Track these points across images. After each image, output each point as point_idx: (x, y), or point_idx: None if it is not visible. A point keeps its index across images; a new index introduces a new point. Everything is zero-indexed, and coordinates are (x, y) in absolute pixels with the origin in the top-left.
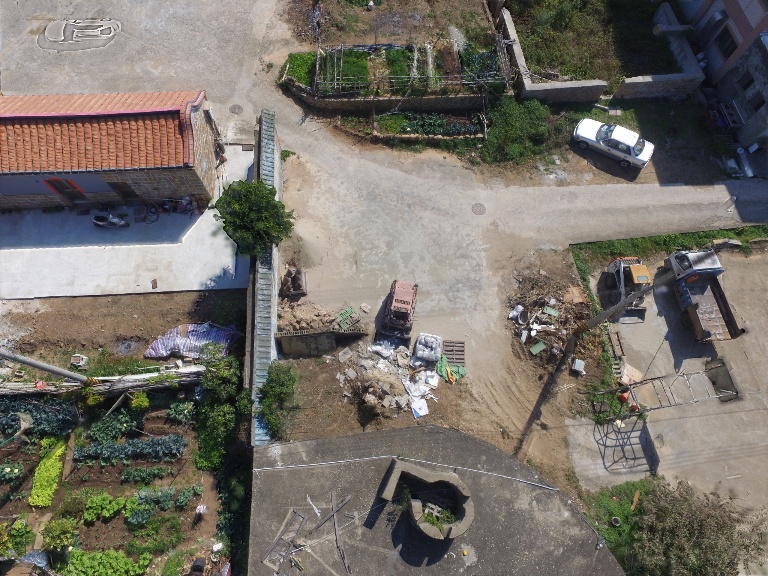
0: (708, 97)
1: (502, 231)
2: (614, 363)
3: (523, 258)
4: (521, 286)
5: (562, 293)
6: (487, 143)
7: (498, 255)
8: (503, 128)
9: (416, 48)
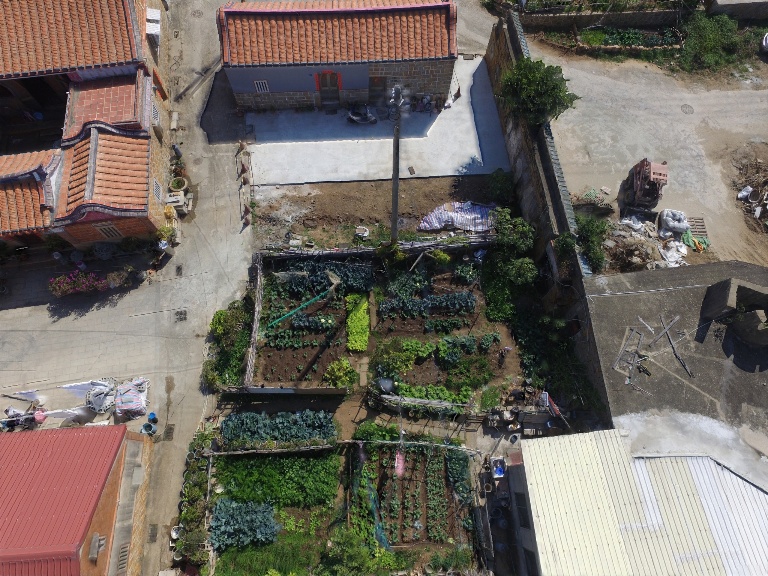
0: None
1: (713, 127)
2: None
3: (738, 149)
4: (743, 172)
5: None
6: (685, 53)
7: (714, 147)
8: (697, 40)
9: None
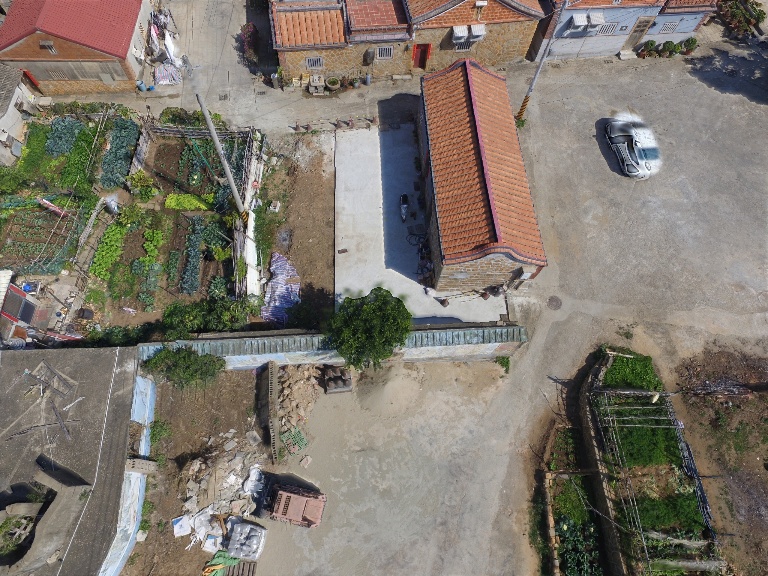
0: None
1: None
2: None
3: None
4: None
5: None
6: None
7: None
8: None
9: None
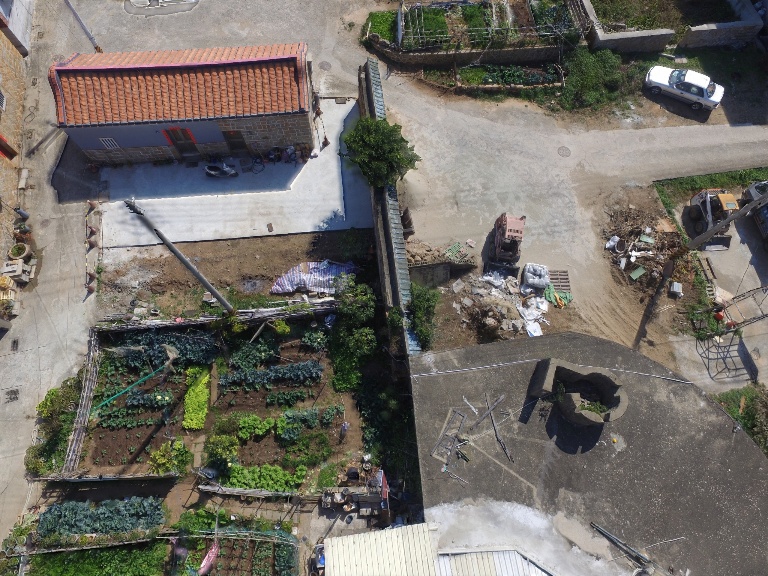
0: (766, 44)
1: (589, 171)
2: (707, 285)
3: (612, 194)
4: (613, 219)
5: (655, 222)
6: (566, 91)
7: (588, 193)
8: (579, 77)
9: (493, 3)
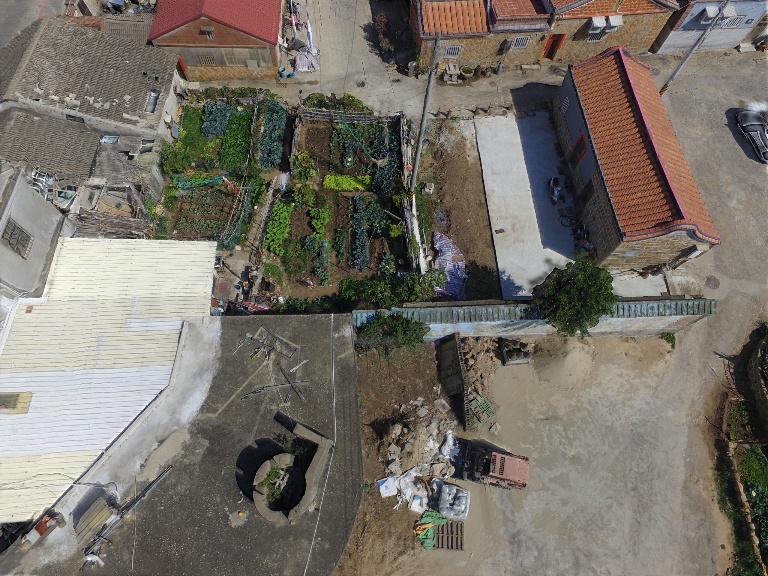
0: None
1: None
2: None
3: None
4: None
5: None
6: None
7: None
8: None
9: None
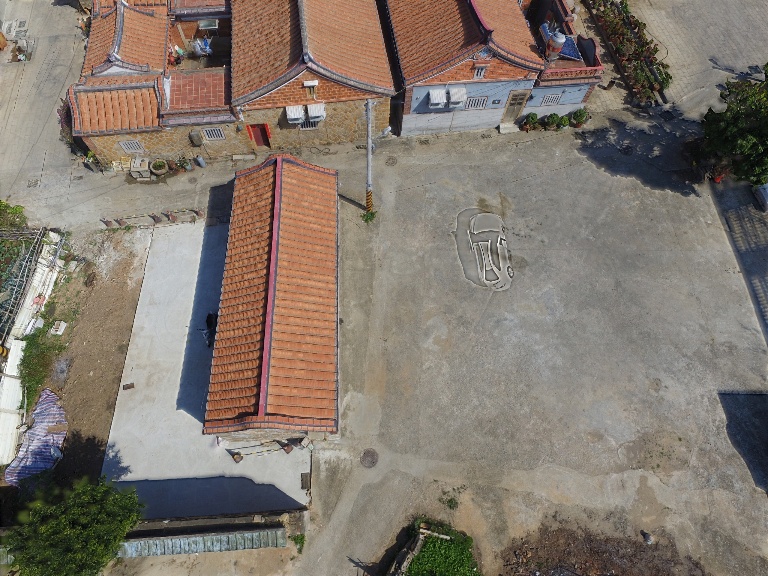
0: None
1: None
2: None
3: None
4: None
5: None
6: None
7: None
8: None
9: None
